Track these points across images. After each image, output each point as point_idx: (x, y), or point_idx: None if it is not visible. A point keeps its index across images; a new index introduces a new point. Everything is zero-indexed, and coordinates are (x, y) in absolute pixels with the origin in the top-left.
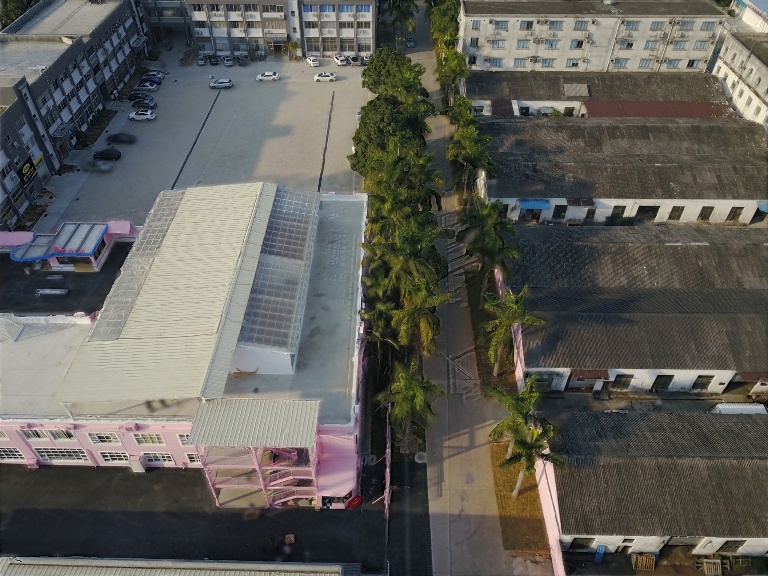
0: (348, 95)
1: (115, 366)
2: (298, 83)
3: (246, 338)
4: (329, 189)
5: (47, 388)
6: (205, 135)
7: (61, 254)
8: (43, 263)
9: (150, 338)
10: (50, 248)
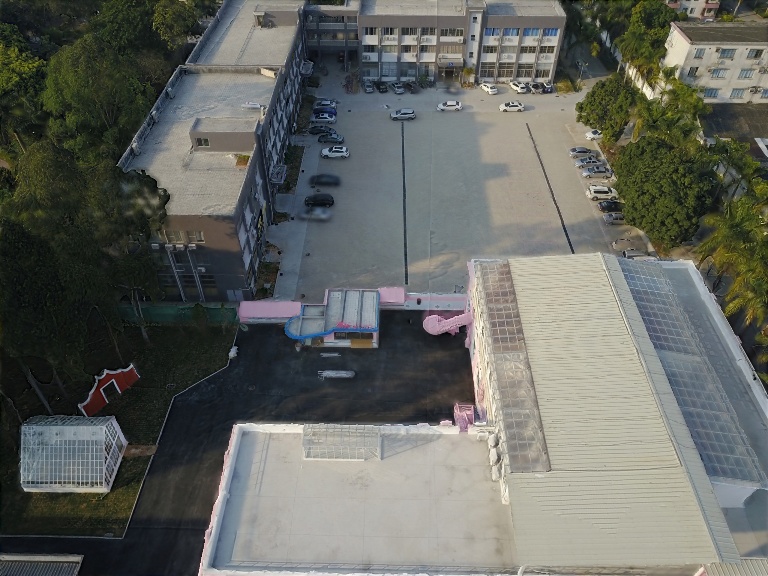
0: (545, 128)
1: (574, 512)
2: (483, 113)
3: (712, 470)
4: (581, 241)
5: (454, 527)
6: (411, 175)
7: (342, 330)
8: (313, 338)
9: (594, 470)
10: (326, 322)
